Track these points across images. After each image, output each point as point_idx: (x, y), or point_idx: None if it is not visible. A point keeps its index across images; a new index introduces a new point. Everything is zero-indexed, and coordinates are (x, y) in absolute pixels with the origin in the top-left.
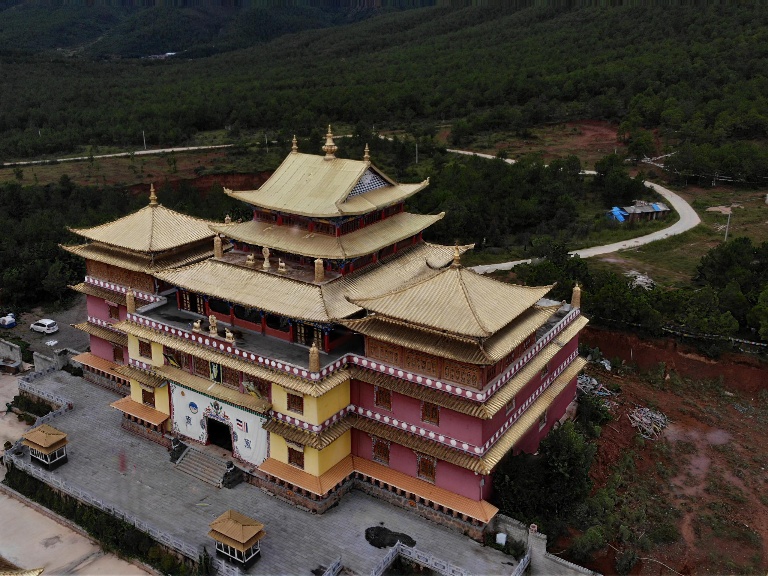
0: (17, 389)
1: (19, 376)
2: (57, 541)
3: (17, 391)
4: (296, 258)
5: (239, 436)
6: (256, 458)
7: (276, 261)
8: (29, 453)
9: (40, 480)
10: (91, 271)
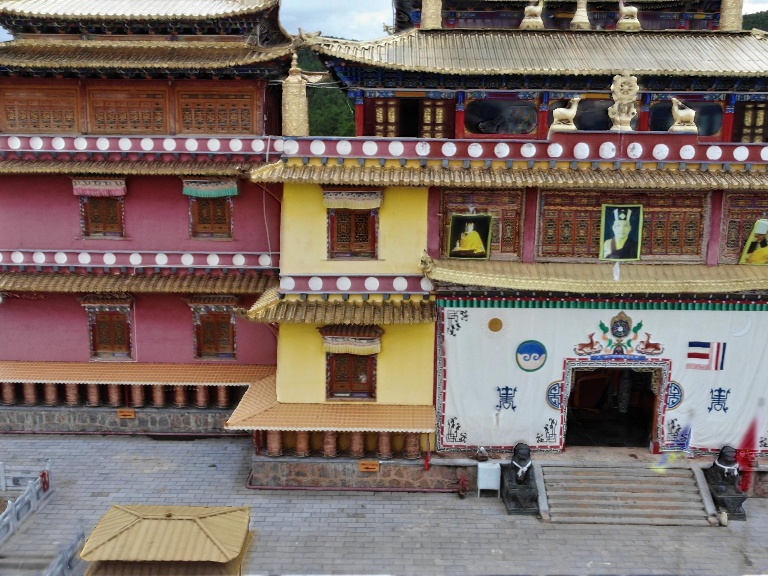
0: None
1: None
2: None
3: None
4: None
5: (691, 388)
6: (746, 430)
7: None
8: None
9: None
10: (10, 119)
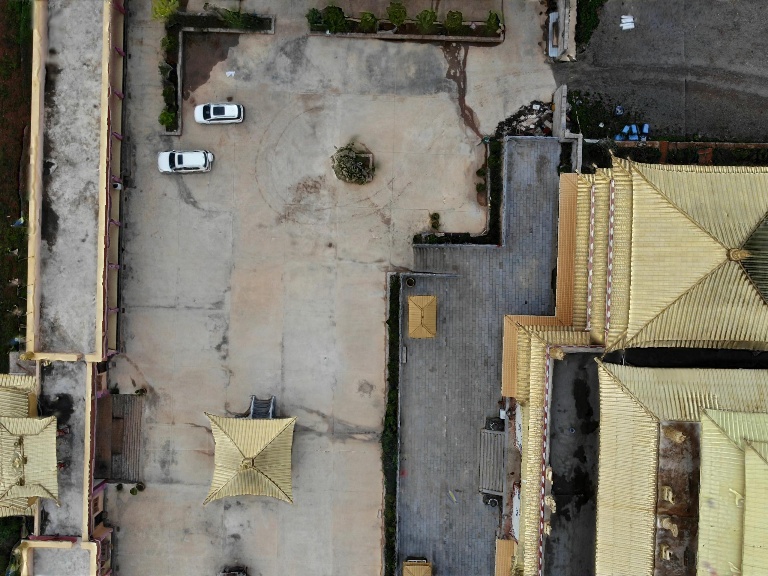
0: (523, 98)
1: (547, 66)
2: (368, 392)
3: (520, 103)
4: None
5: (518, 503)
6: None
7: (696, 514)
8: (421, 282)
9: (399, 331)
10: None
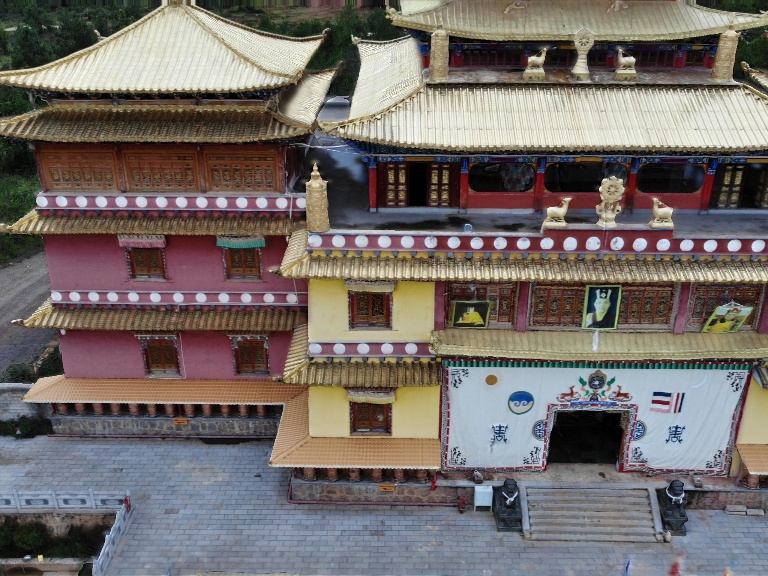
0: None
1: None
2: None
3: None
4: (596, 56)
5: (653, 425)
6: (695, 456)
7: (557, 69)
8: None
9: None
10: (55, 179)
